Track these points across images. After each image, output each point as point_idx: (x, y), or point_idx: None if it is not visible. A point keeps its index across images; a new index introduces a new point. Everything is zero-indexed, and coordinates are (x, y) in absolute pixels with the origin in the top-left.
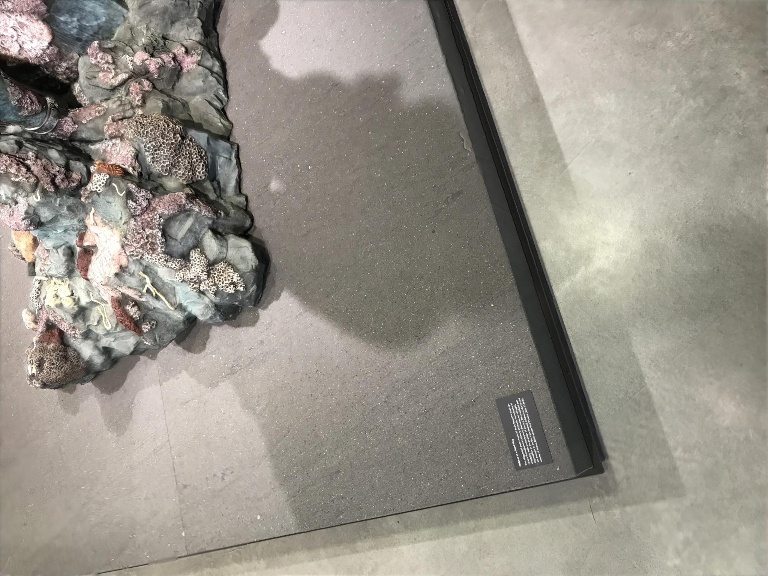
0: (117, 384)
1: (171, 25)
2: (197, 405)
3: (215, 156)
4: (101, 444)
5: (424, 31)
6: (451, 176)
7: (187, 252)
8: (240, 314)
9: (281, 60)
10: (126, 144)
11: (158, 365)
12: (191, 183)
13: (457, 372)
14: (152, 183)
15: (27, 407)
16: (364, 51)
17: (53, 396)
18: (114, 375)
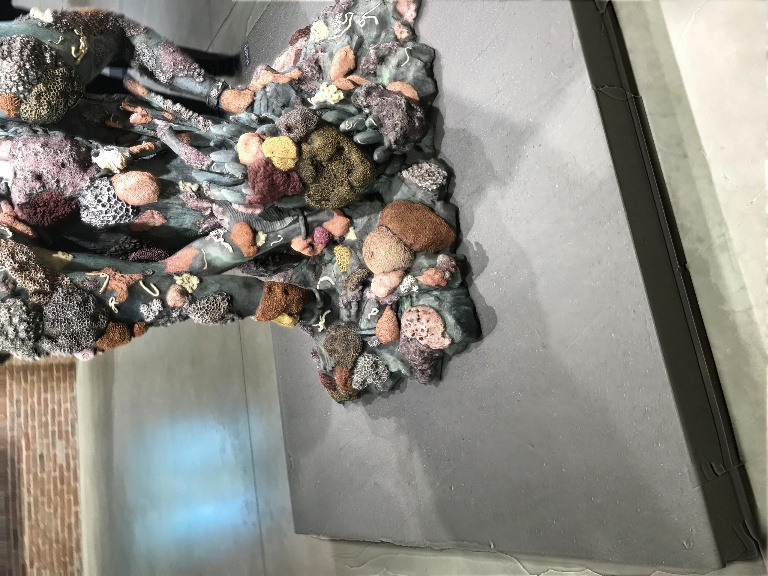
0: None
1: None
2: (322, 0)
3: None
4: None
5: None
6: None
7: None
8: None
9: None
10: None
11: None
12: None
13: None
14: None
15: None
16: None
17: None
18: None
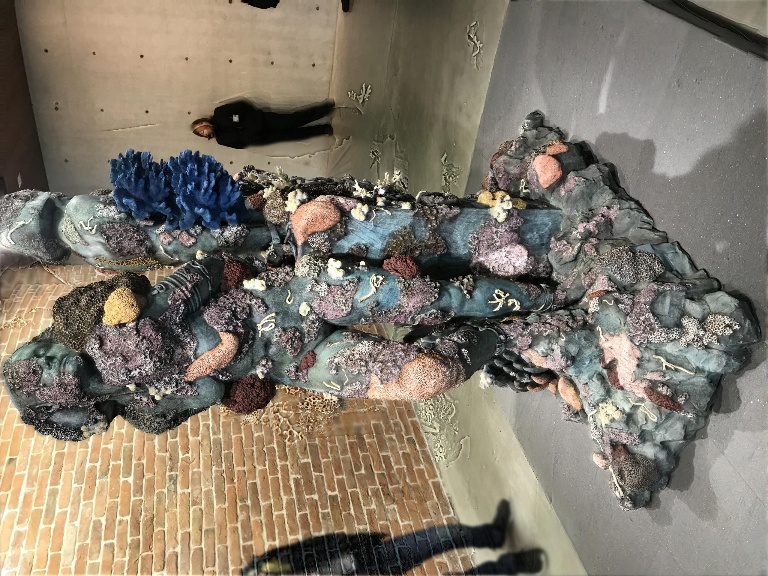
0: (689, 476)
1: (590, 200)
2: (762, 451)
3: (663, 255)
4: (704, 535)
5: (760, 69)
6: None
7: (678, 321)
8: (752, 355)
9: (673, 169)
10: (599, 276)
11: (712, 440)
12: (656, 279)
13: None
14: (629, 291)
15: (632, 540)
16: (726, 116)
17: (647, 519)
18: (683, 471)
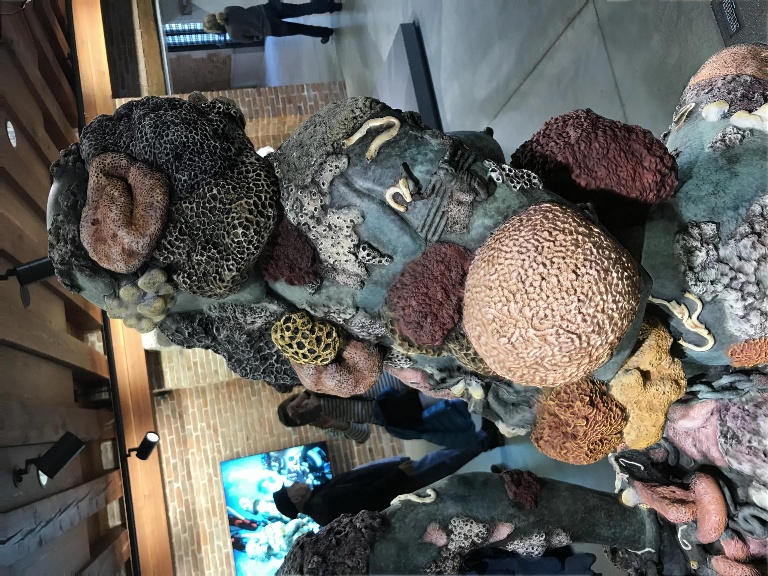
0: None
1: None
2: None
3: None
4: None
5: None
6: None
7: None
8: None
9: None
10: None
11: None
12: None
13: (767, 34)
14: None
15: None
16: None
17: None
18: None
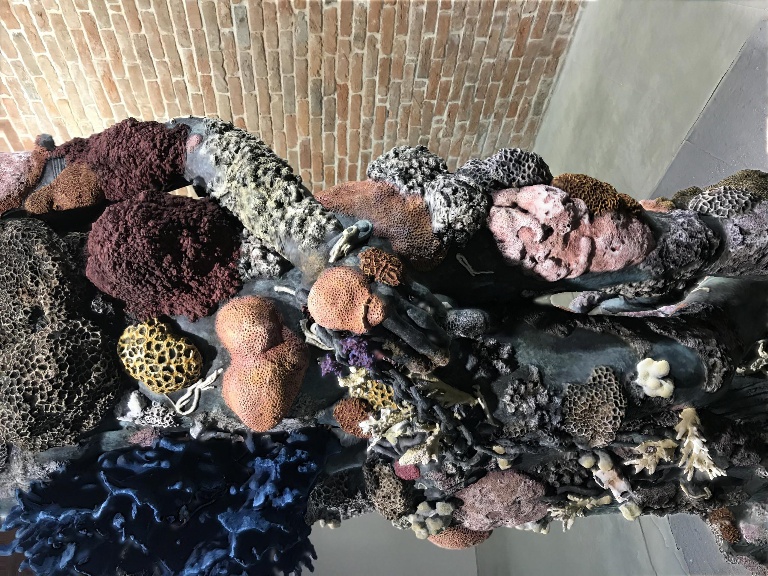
0: None
1: None
2: None
3: None
4: None
5: None
6: None
7: None
8: None
9: None
10: (763, 535)
11: None
12: None
13: None
14: (762, 545)
15: None
16: None
17: None
18: None
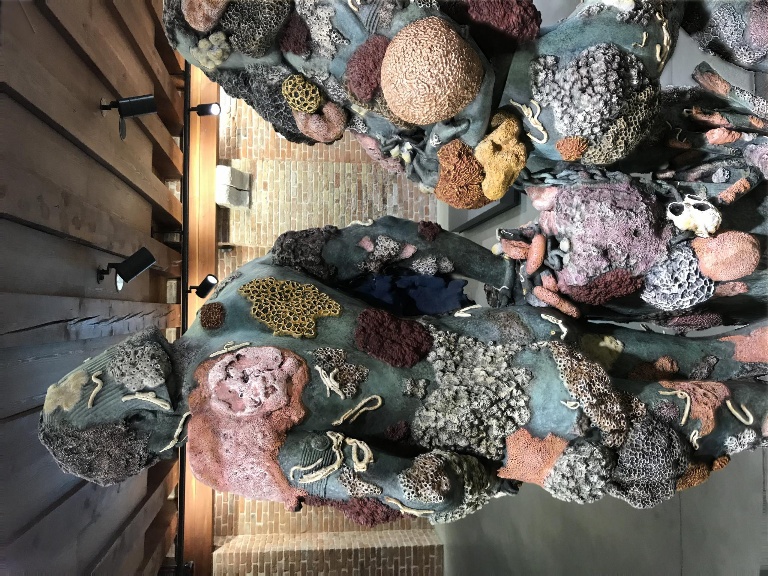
0: None
1: None
2: None
3: None
4: None
5: None
6: (766, 83)
7: None
8: None
9: None
10: None
11: None
12: None
13: None
14: None
15: None
16: None
17: None
18: None
